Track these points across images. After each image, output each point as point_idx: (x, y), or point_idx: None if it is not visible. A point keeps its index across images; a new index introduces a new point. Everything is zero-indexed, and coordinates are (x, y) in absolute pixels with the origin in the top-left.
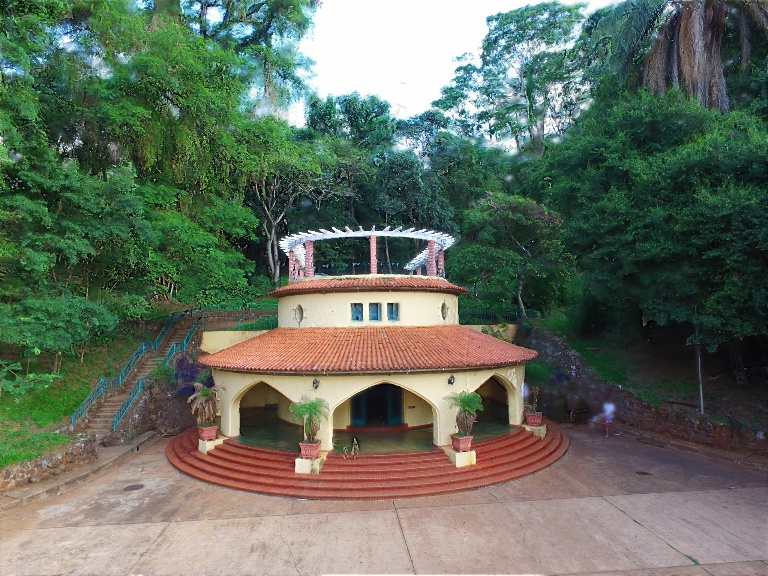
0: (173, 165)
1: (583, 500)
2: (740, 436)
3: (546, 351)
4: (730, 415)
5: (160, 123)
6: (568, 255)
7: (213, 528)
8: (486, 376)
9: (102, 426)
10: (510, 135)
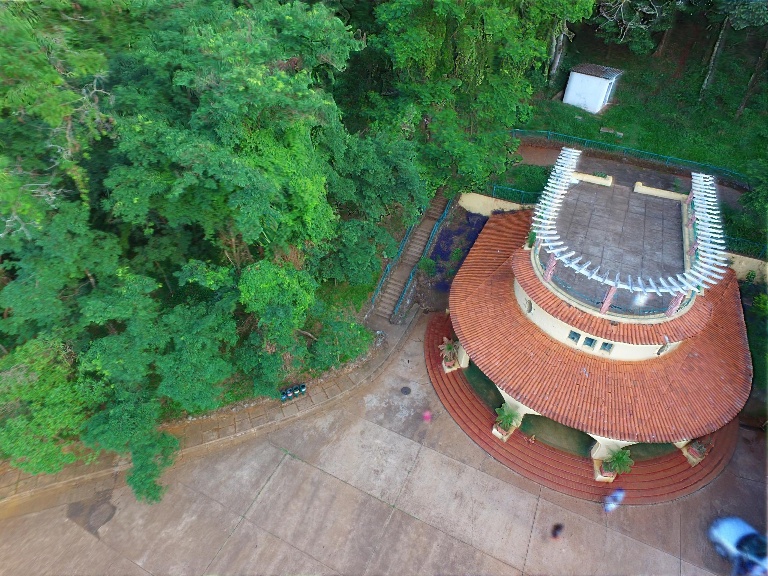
0: None
1: (664, 556)
2: None
3: None
4: None
5: None
6: None
7: (441, 463)
8: None
9: (389, 303)
10: None
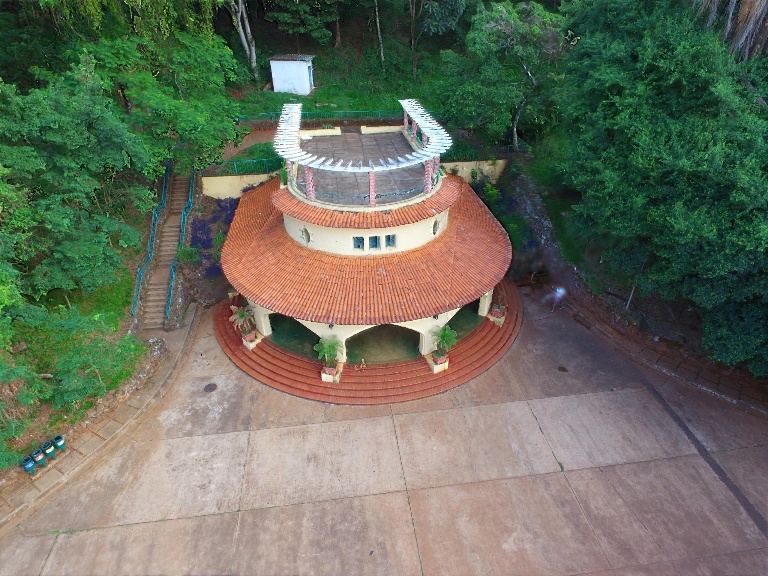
0: None
1: (514, 405)
2: (643, 335)
3: (526, 207)
4: (645, 315)
5: None
6: None
7: (279, 438)
8: None
9: (156, 311)
10: None
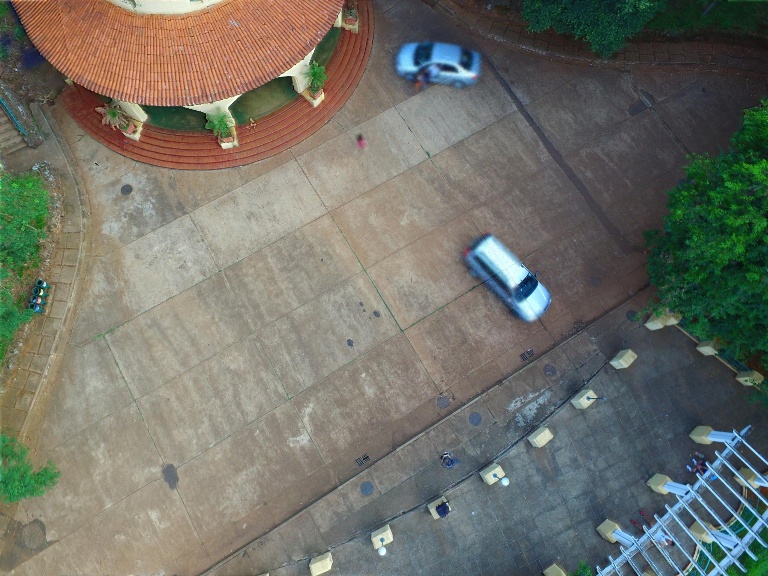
0: None
1: (386, 114)
2: (478, 5)
3: None
4: None
5: None
6: None
7: (216, 210)
8: None
9: (3, 130)
10: None
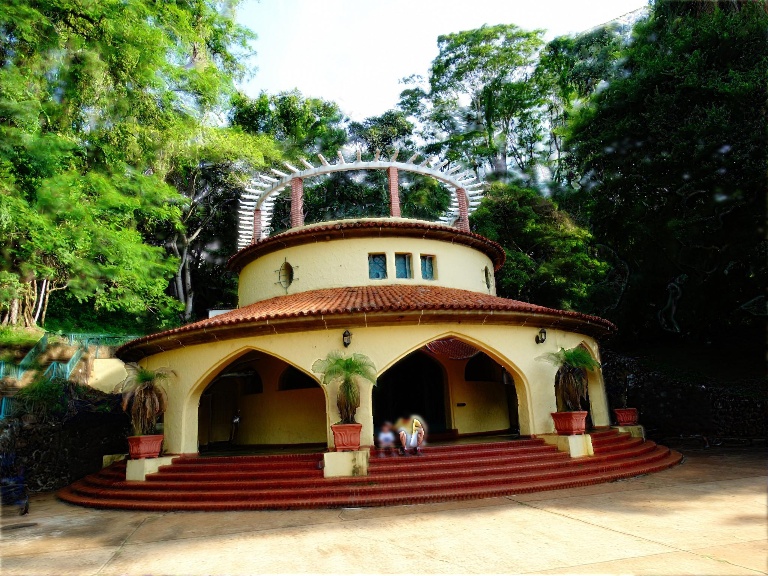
0: (58, 133)
1: None
2: None
3: None
4: None
5: (58, 47)
6: (586, 258)
7: (217, 542)
8: (576, 341)
9: None
10: (468, 165)
